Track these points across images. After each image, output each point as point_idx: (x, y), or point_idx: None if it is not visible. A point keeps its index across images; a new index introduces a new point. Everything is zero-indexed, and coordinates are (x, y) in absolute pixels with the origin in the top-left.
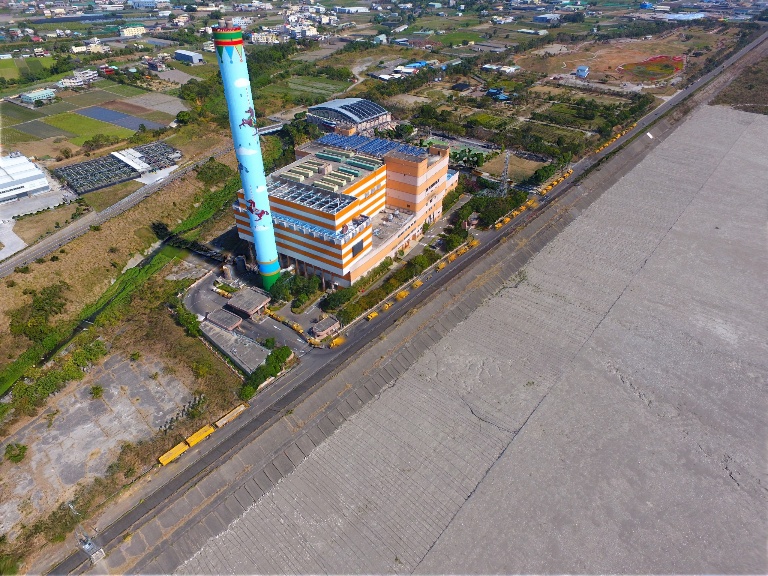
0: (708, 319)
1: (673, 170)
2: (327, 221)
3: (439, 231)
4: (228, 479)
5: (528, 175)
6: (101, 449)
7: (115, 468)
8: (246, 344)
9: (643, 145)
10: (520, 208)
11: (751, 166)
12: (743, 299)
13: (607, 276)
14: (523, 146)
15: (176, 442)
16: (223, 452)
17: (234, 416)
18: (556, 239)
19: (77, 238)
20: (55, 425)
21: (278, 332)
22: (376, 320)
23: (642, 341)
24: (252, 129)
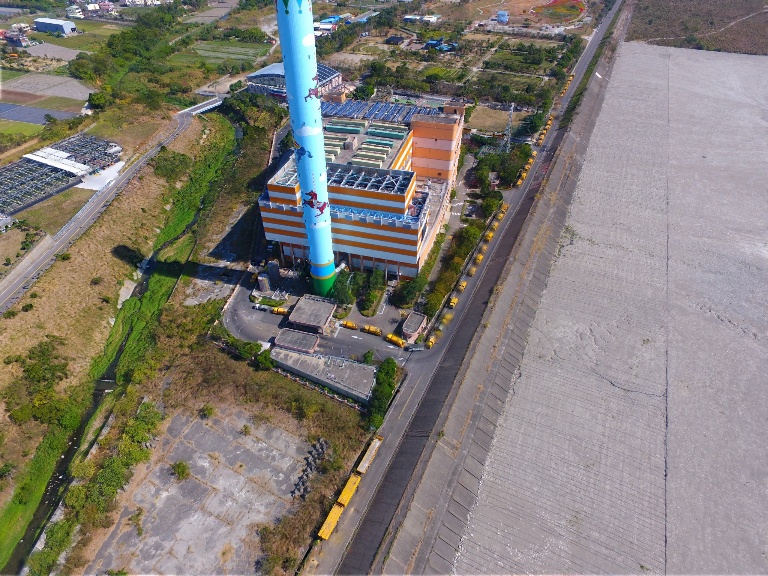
0: (751, 245)
1: (635, 106)
2: (393, 204)
3: (463, 197)
4: (417, 534)
5: (514, 126)
6: (231, 543)
7: (265, 563)
8: (341, 365)
9: (597, 85)
10: (530, 161)
11: (695, 96)
12: (765, 220)
13: (645, 218)
14: (493, 97)
15: (326, 507)
16: (394, 503)
17: (373, 455)
18: (578, 188)
19: (45, 274)
20: (147, 529)
21: (362, 342)
22: (461, 306)
23: (713, 277)
24: (317, 101)
